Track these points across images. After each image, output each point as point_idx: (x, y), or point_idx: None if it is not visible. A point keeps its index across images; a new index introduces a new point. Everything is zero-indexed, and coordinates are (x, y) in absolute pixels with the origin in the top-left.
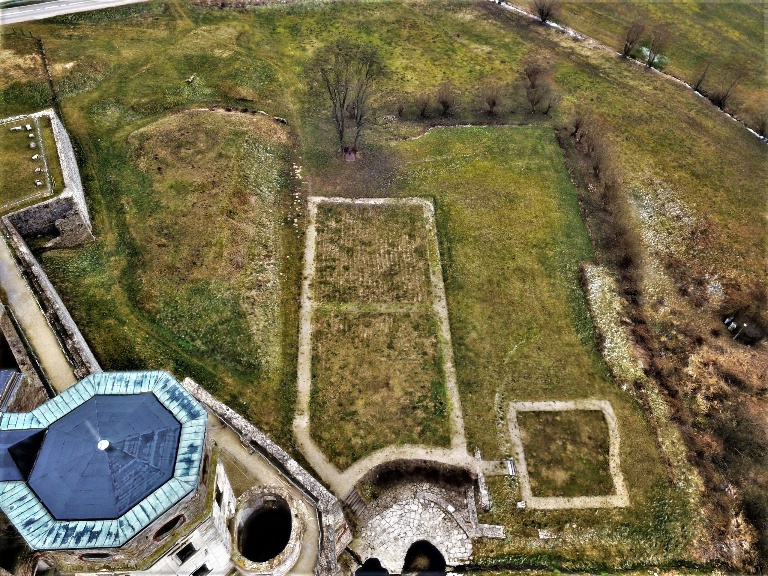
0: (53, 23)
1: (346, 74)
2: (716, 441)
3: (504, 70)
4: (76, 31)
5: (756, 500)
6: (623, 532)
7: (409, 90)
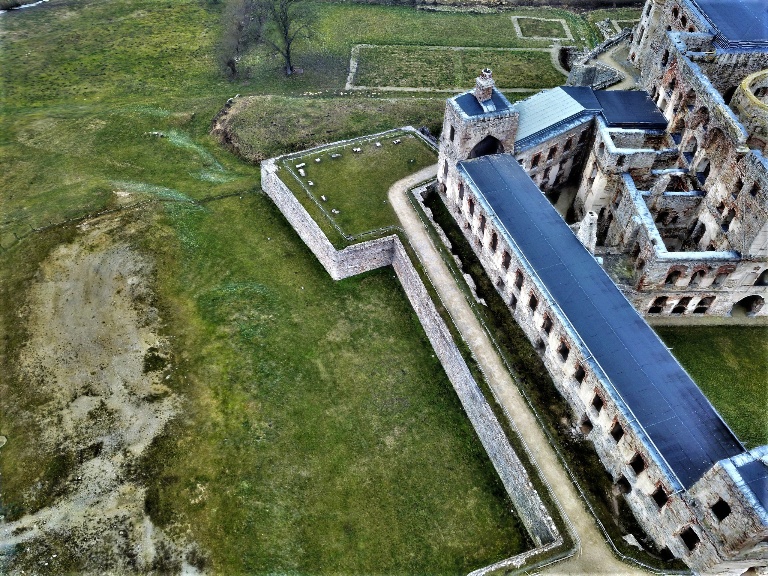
0: None
1: (280, 0)
2: (521, 4)
3: (183, 8)
4: None
5: (548, 2)
6: (576, 24)
7: (196, 47)
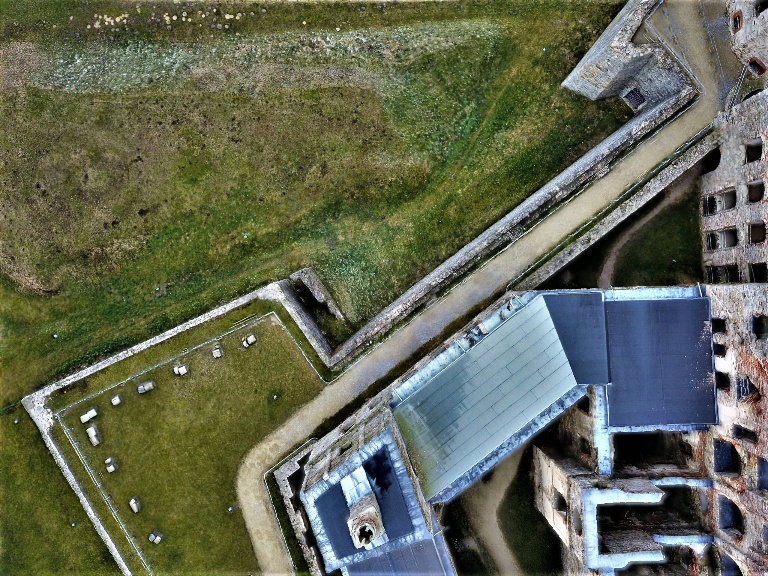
0: None
1: None
2: None
3: None
4: None
5: None
6: None
7: None
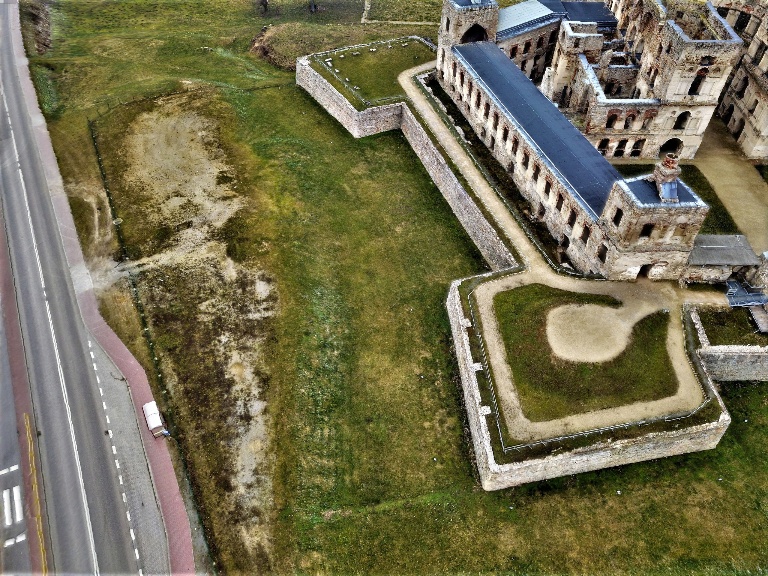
0: (58, 115)
1: None
2: None
3: None
4: (81, 104)
5: None
6: None
7: None
